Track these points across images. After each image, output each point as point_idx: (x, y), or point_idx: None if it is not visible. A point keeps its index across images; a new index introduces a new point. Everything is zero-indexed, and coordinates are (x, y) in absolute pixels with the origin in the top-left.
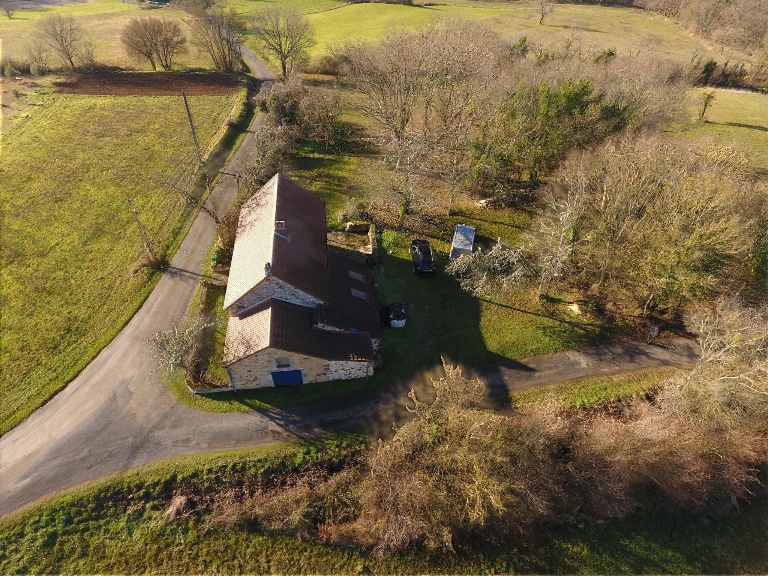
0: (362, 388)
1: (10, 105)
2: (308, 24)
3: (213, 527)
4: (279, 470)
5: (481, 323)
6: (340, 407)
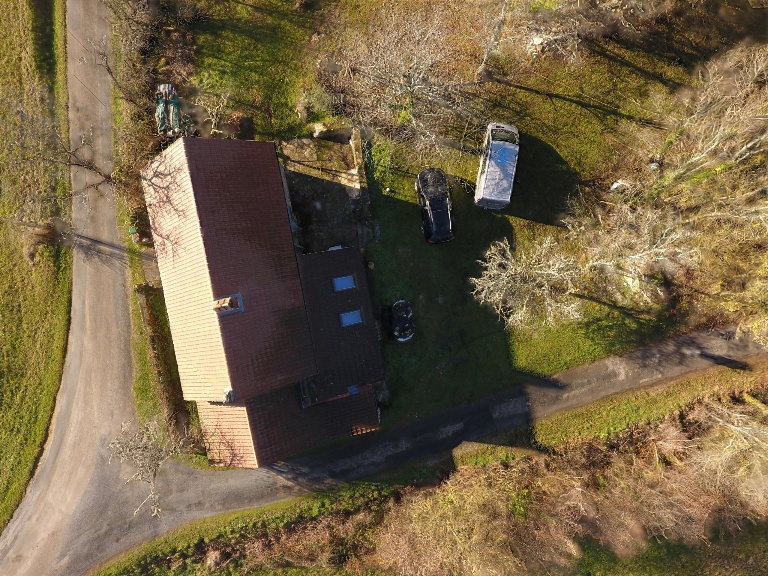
0: None
1: None
2: None
3: (251, 569)
4: (298, 521)
5: None
6: (347, 455)
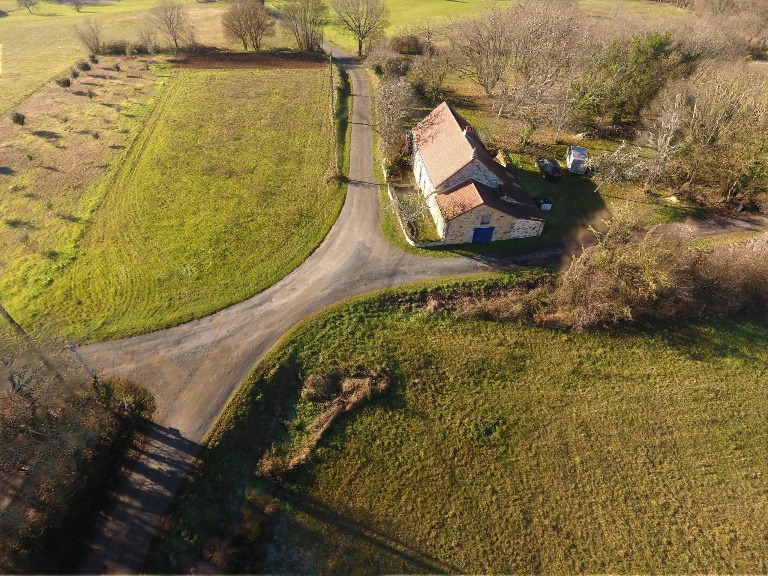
0: (535, 243)
1: None
2: (385, 7)
3: (461, 316)
4: (494, 287)
5: (607, 207)
6: (523, 253)
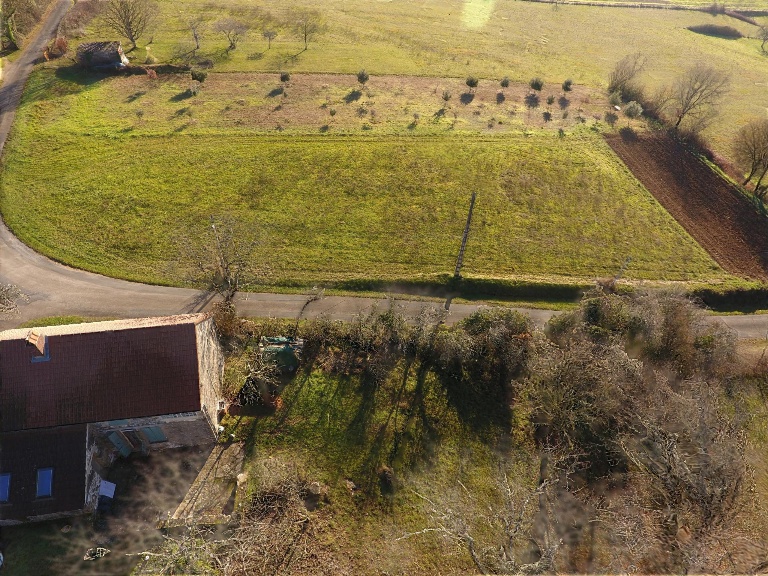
0: None
1: (551, 120)
2: None
3: None
4: None
5: None
6: None
